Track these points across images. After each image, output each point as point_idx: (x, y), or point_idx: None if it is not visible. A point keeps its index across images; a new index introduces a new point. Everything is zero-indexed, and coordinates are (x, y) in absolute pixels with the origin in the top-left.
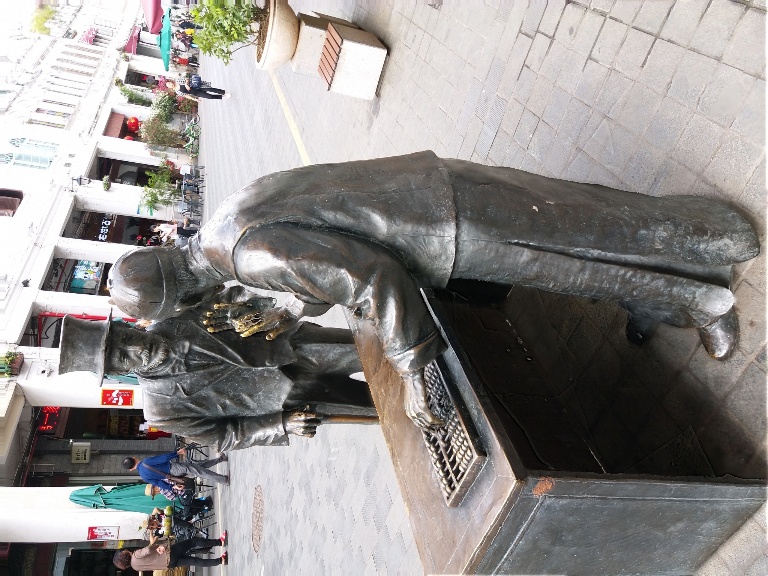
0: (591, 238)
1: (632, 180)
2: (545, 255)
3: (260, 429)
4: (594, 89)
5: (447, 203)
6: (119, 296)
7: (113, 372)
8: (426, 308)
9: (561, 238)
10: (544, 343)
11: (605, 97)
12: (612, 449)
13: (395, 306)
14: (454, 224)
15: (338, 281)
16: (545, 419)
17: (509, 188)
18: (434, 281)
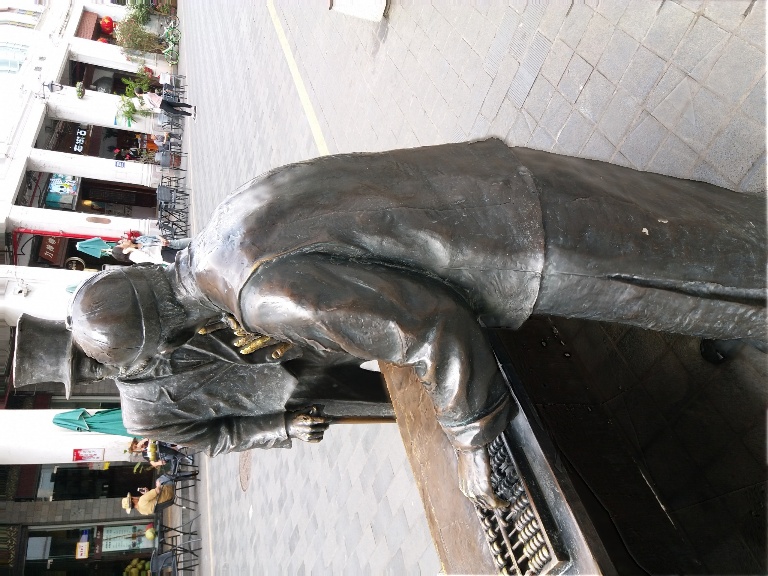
0: (711, 269)
1: (719, 161)
2: (652, 292)
3: (259, 432)
4: (672, 38)
5: (533, 226)
6: (81, 339)
7: (83, 383)
8: (496, 364)
9: (674, 270)
10: (587, 339)
11: (687, 50)
12: (671, 478)
13: (459, 368)
14: (542, 256)
15: (385, 337)
16: (590, 435)
17: (612, 202)
18: (504, 322)
